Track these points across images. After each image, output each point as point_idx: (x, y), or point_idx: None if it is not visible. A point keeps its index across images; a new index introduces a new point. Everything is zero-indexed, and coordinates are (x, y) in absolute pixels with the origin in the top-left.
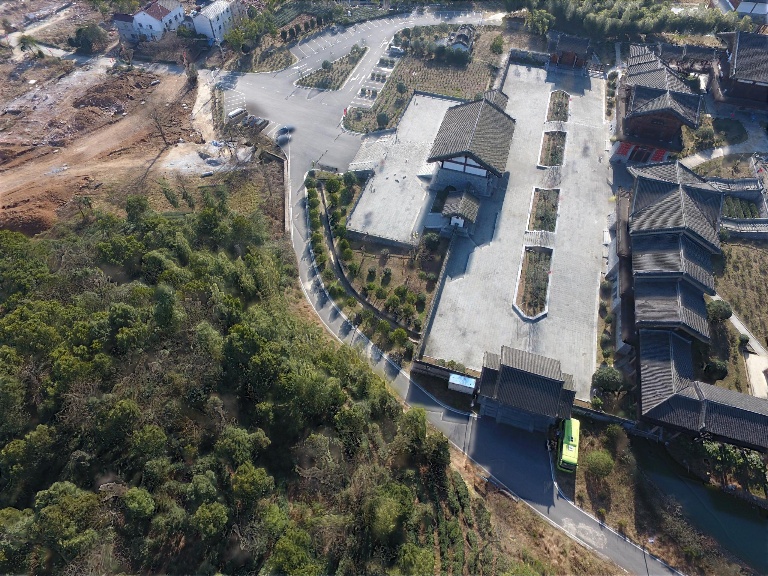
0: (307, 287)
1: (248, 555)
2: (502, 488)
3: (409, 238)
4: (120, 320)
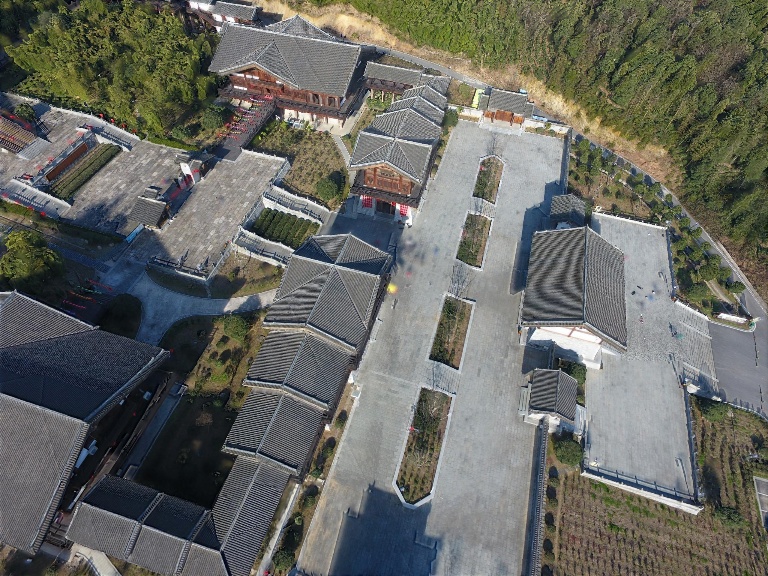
0: (666, 191)
1: None
2: None
3: (601, 222)
4: (763, 81)
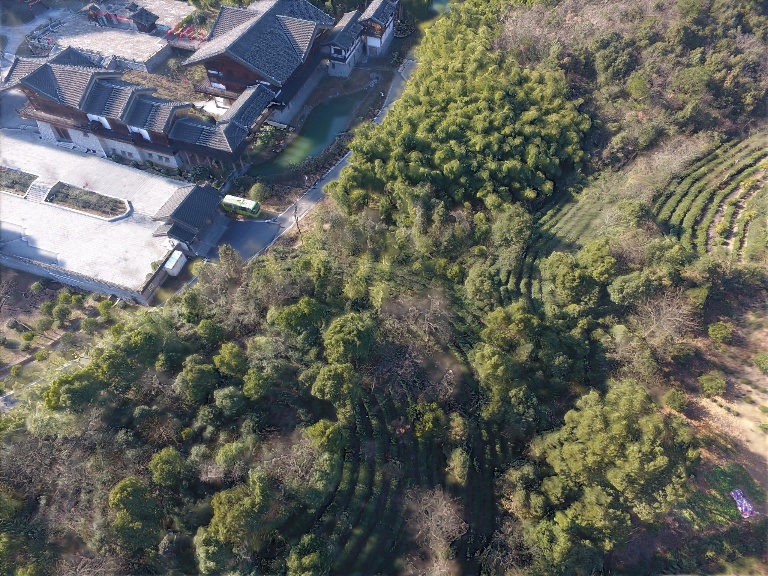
0: None
1: (288, 370)
2: (264, 250)
3: None
4: None
